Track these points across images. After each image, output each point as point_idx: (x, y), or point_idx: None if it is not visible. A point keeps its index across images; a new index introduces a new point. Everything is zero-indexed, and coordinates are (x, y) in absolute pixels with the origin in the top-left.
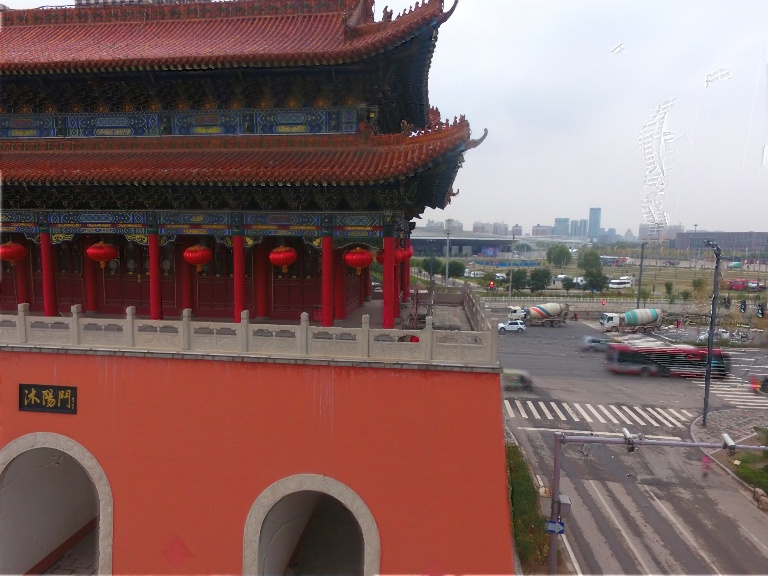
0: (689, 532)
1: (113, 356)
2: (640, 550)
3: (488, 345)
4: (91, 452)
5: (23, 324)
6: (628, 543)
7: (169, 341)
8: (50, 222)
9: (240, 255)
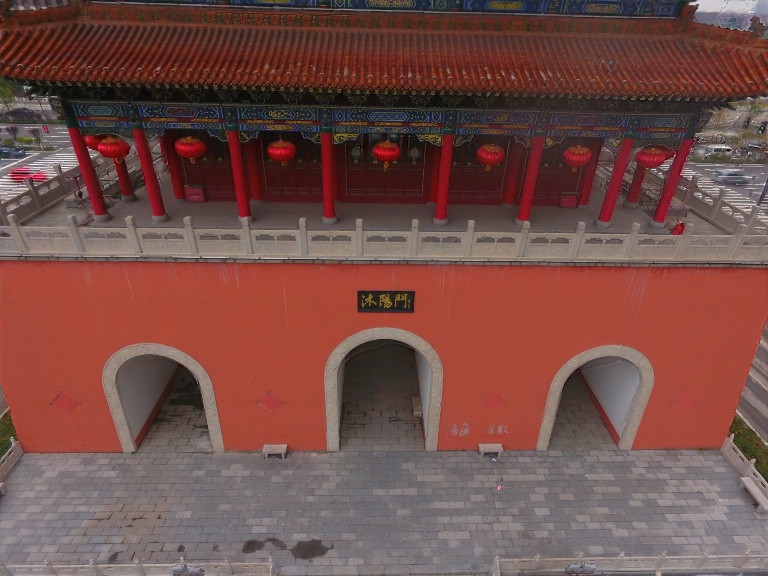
0: (762, 340)
1: (453, 265)
2: None
3: None
4: (426, 340)
5: (361, 239)
6: None
7: (505, 250)
8: (334, 120)
9: (539, 156)
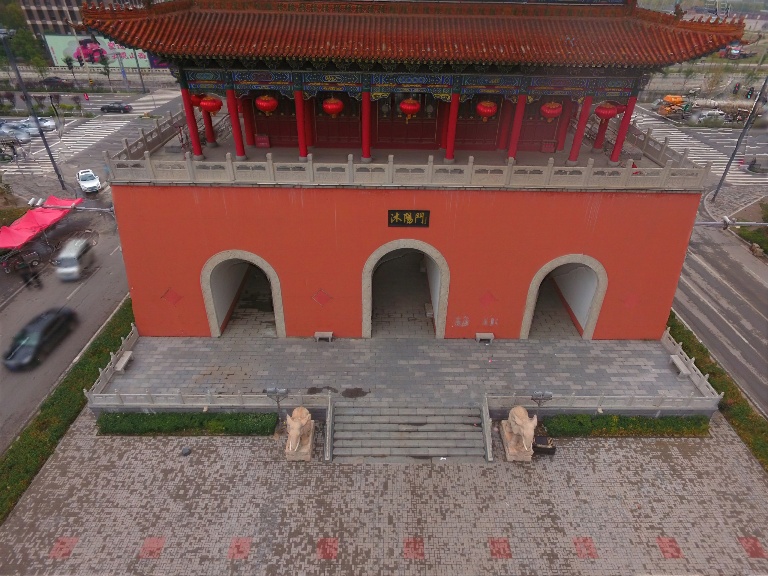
0: (716, 271)
1: (457, 190)
2: (691, 283)
3: (701, 177)
4: (437, 249)
5: (392, 170)
6: (683, 280)
7: (496, 179)
8: (372, 83)
9: (523, 110)
